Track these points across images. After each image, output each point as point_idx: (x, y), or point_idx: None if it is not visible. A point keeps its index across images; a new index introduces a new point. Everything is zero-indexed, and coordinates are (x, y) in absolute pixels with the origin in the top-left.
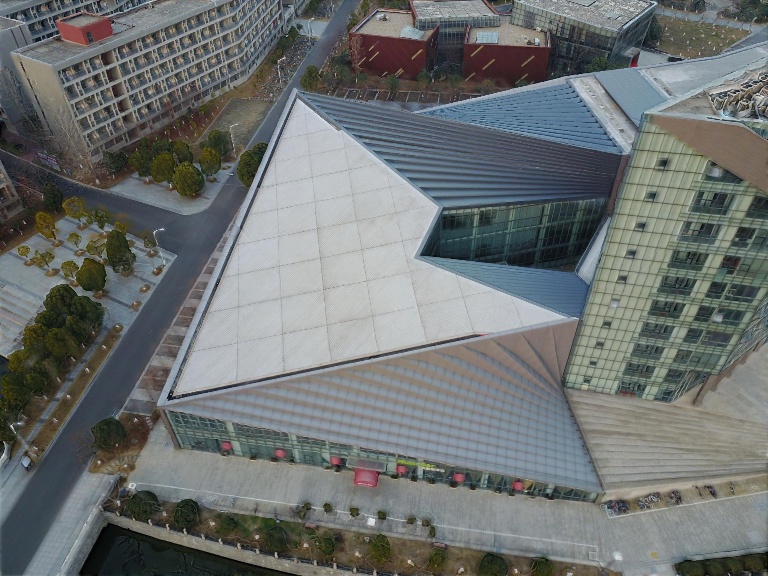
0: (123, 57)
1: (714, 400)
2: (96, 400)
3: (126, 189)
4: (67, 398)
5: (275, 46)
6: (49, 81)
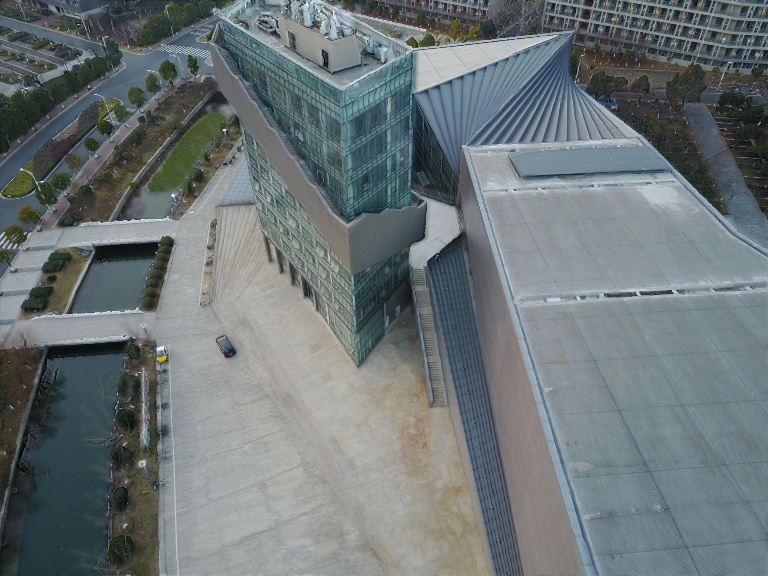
0: None
1: (271, 270)
2: None
3: None
4: None
5: None
6: None
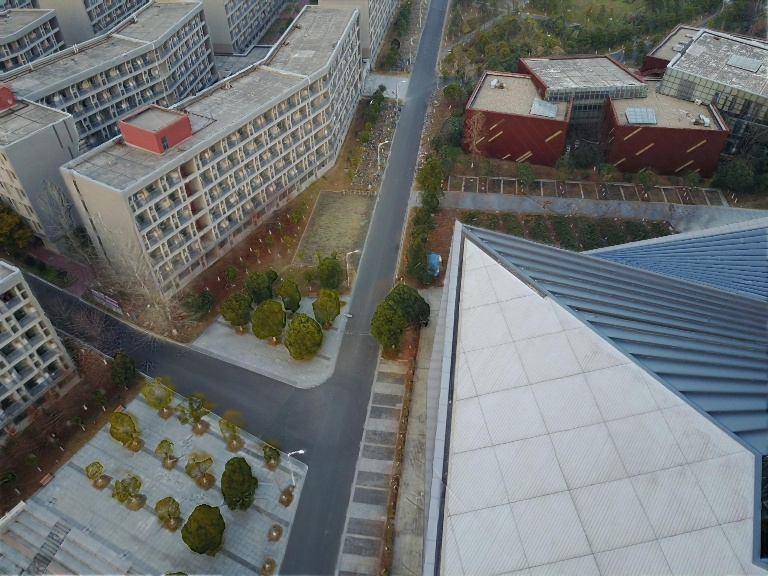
0: (205, 163)
1: None
2: None
3: (214, 343)
4: None
5: (356, 113)
6: (114, 208)
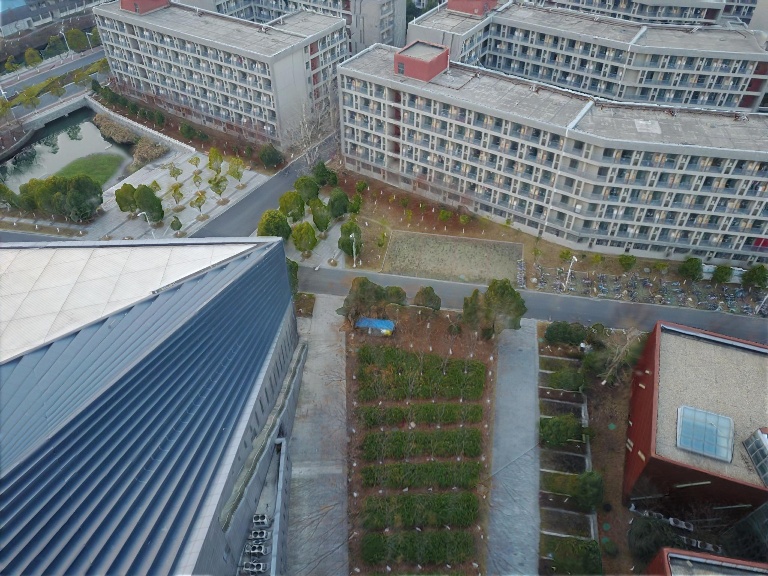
0: (414, 106)
1: None
2: (3, 238)
3: None
4: (14, 224)
5: None
6: None
